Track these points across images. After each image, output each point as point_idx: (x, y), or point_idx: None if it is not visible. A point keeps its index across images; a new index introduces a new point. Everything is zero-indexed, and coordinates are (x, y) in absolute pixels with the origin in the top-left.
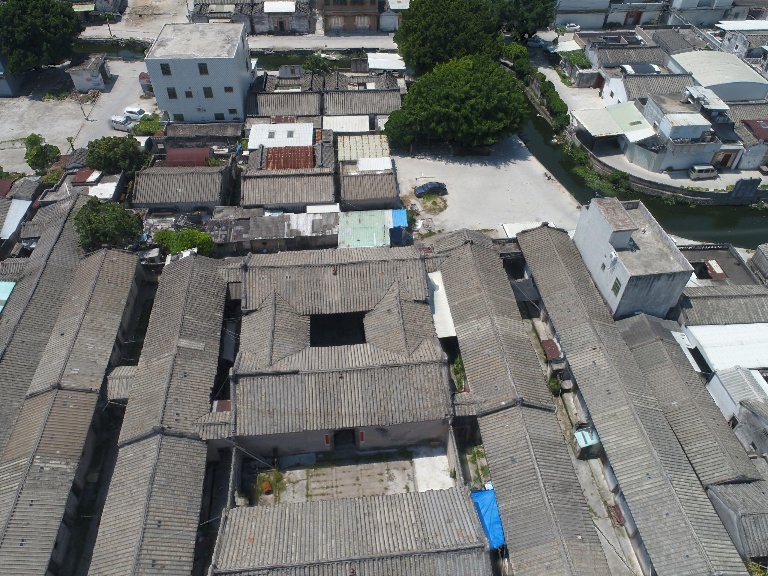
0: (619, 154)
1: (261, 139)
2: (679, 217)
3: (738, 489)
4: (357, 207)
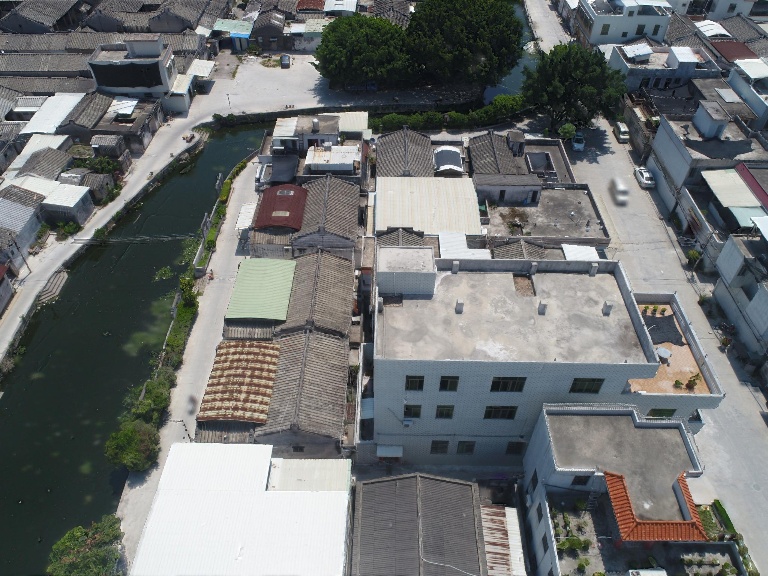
0: None
1: None
2: (221, 166)
3: None
4: None
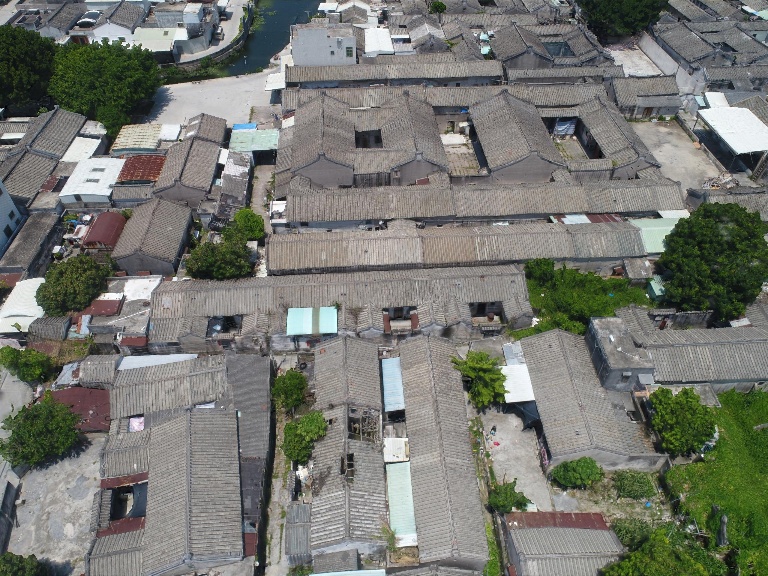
0: (180, 56)
1: (97, 187)
2: (252, 54)
3: None
4: (223, 144)
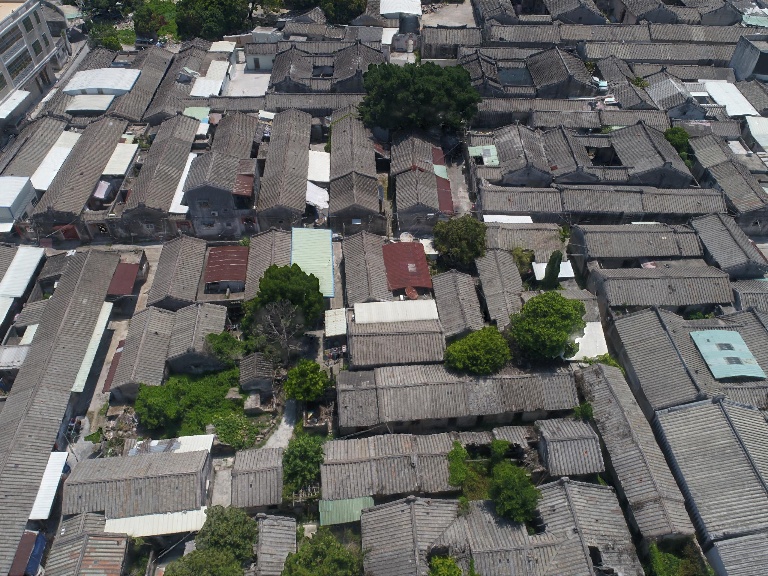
0: None
1: None
2: None
3: (627, 67)
4: None
